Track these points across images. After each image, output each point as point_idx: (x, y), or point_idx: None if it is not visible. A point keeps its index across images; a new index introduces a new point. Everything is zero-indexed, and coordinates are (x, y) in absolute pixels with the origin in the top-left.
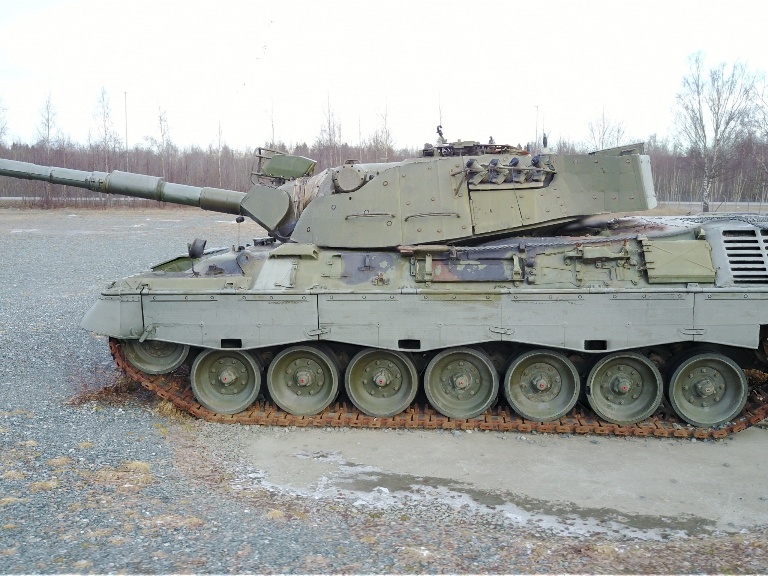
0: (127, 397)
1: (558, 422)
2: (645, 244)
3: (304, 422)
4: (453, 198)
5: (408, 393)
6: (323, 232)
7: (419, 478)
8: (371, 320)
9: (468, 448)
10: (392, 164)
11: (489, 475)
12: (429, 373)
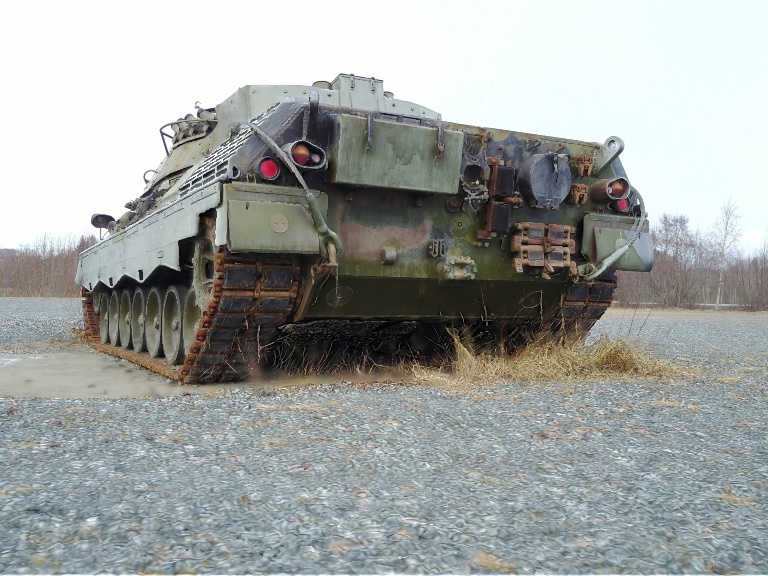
0: None
1: None
2: None
3: (100, 348)
4: None
5: None
6: None
7: None
8: None
9: (81, 363)
10: None
11: (15, 367)
12: (132, 311)
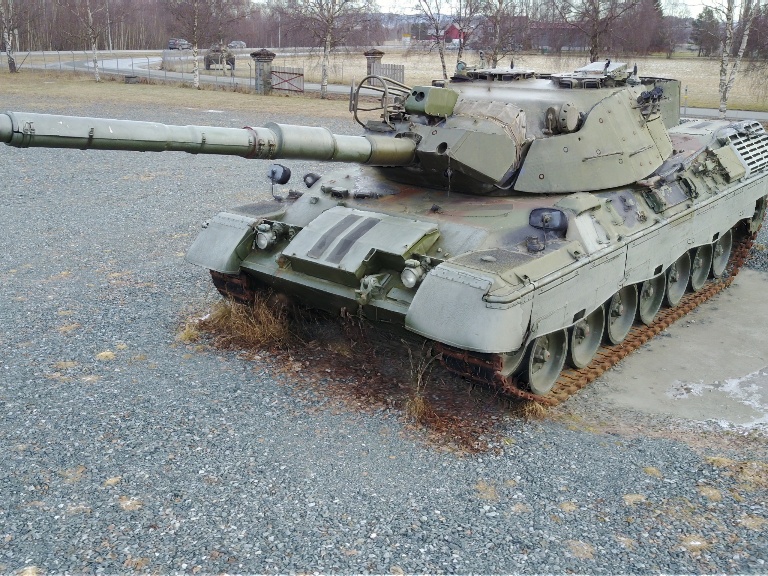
0: (458, 420)
1: (681, 302)
2: (717, 153)
3: None
4: (642, 130)
5: (631, 314)
6: (562, 178)
7: (764, 374)
8: None
9: (703, 342)
10: (569, 97)
11: None
12: None
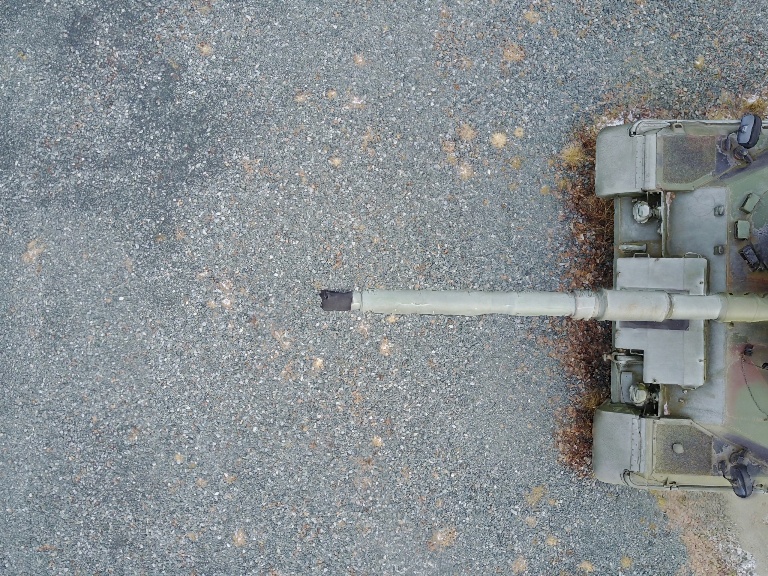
0: None
1: None
2: None
3: None
4: None
5: None
6: None
7: None
8: None
9: None
10: None
11: None
12: None
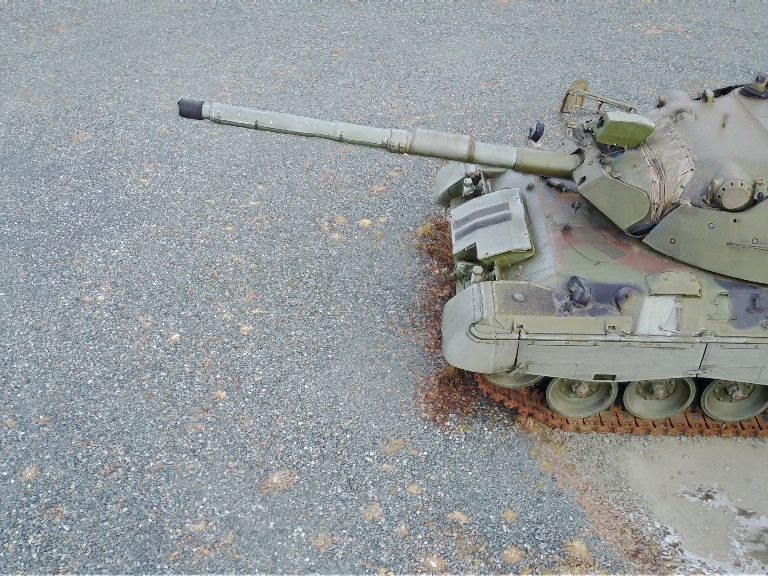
0: (469, 394)
1: None
2: None
3: (659, 432)
4: None
5: (760, 404)
6: (694, 250)
7: None
8: (756, 364)
9: None
10: None
11: None
12: None
